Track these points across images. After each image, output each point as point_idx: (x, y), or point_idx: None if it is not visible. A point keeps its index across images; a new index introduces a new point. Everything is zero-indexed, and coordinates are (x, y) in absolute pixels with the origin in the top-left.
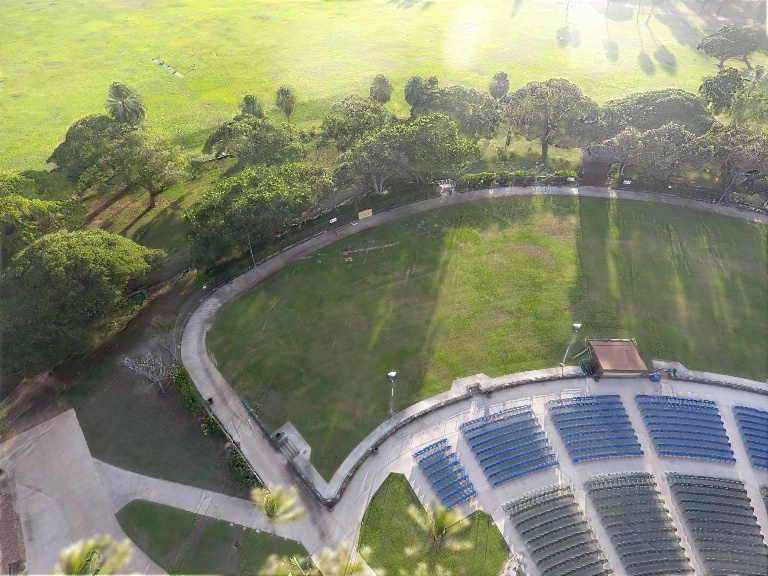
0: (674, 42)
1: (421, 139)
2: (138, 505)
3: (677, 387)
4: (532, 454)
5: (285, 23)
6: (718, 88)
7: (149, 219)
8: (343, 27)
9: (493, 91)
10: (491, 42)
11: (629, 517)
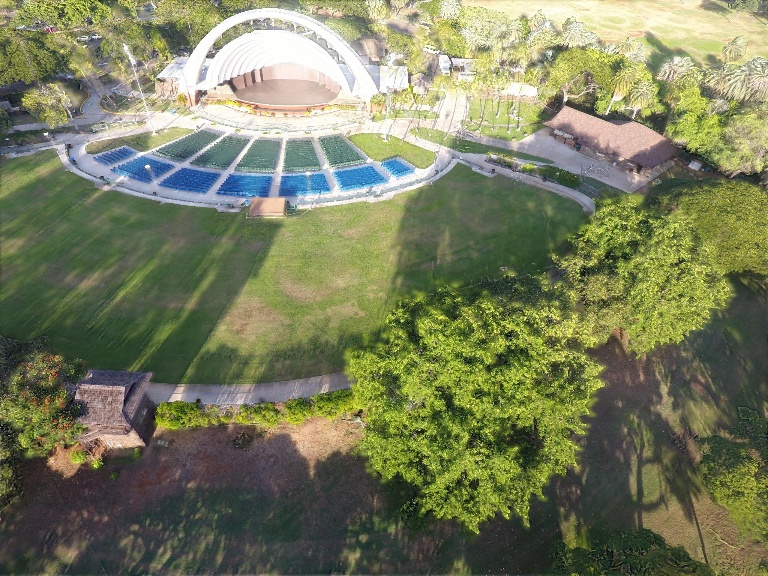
0: None
1: None
2: (547, 162)
3: (233, 203)
4: (347, 174)
5: None
6: None
7: None
8: None
9: None
10: None
11: None
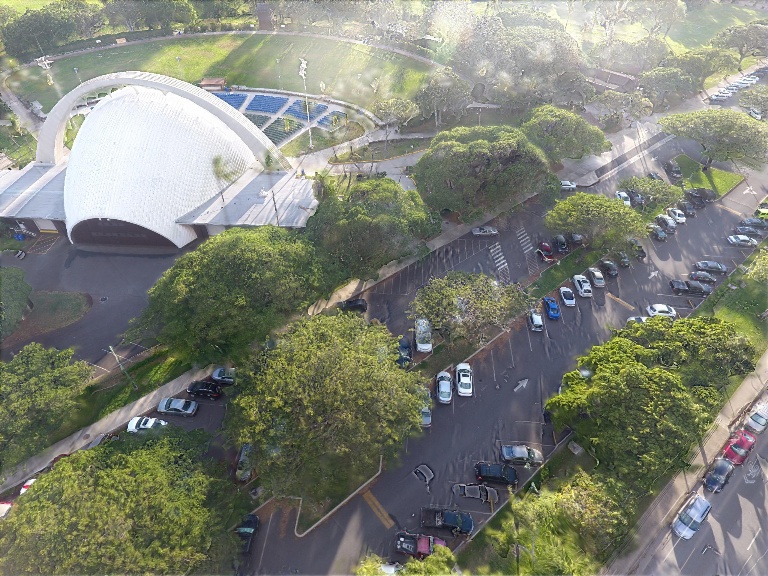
0: None
1: None
2: None
3: None
4: None
5: None
6: None
7: (1, 54)
8: None
9: None
10: None
11: None
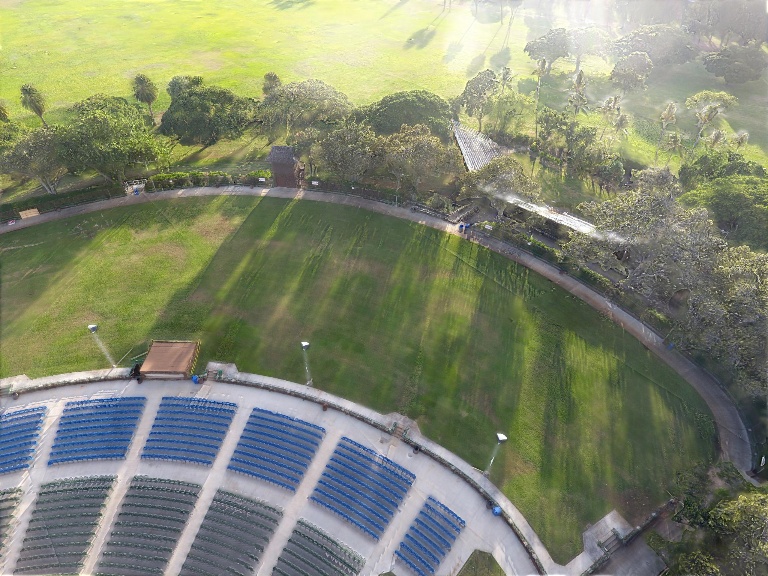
0: (522, 44)
1: (66, 138)
2: None
3: (216, 389)
4: (7, 456)
5: (146, 23)
6: (471, 90)
7: None
8: (201, 27)
9: (265, 91)
10: (337, 43)
11: (56, 521)
